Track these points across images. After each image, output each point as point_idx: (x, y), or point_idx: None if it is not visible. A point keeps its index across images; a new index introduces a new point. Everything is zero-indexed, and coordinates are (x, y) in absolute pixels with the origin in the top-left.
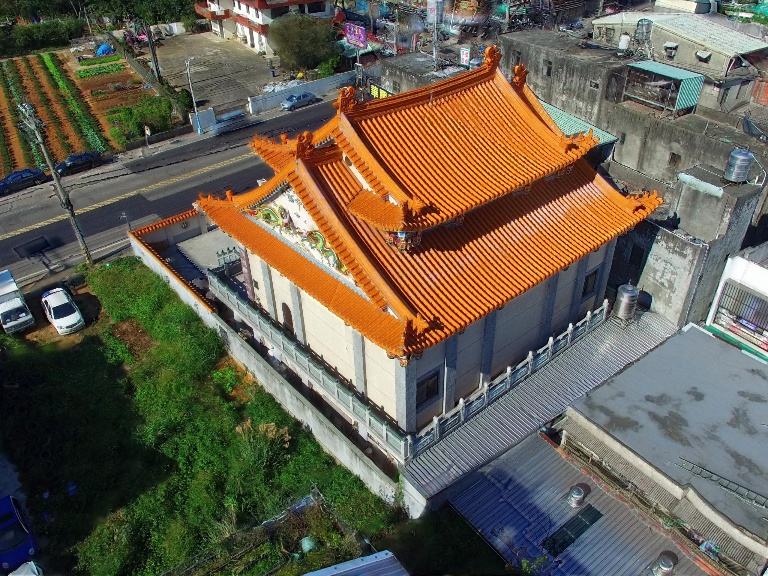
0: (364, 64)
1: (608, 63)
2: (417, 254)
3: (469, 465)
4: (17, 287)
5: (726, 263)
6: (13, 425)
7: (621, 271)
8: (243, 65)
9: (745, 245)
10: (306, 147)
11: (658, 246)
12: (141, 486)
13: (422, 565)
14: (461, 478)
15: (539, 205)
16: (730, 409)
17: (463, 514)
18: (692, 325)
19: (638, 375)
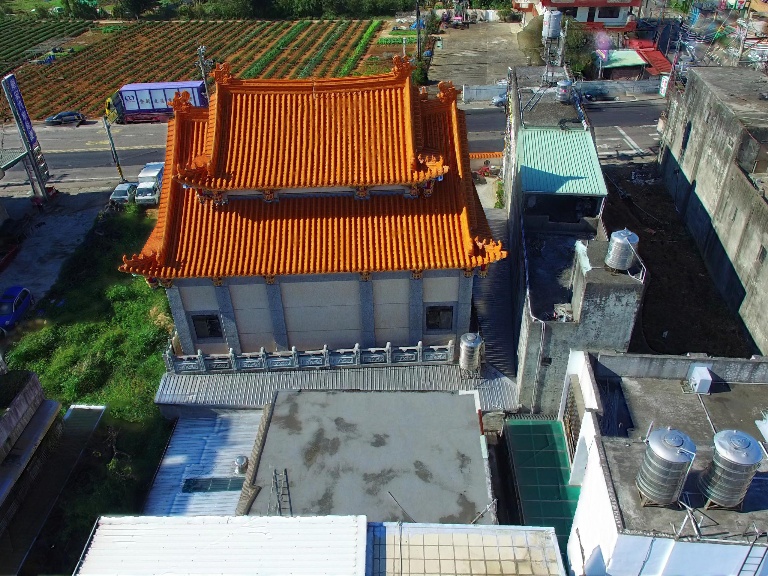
0: (616, 78)
1: (759, 121)
2: (219, 211)
3: (205, 400)
4: (157, 175)
5: (569, 354)
6: (76, 254)
7: (517, 328)
8: (509, 57)
9: (630, 351)
10: (183, 103)
11: (524, 309)
12: (83, 318)
13: (118, 443)
14: (191, 405)
15: (374, 214)
16: (386, 466)
17: (175, 431)
18: (474, 393)
19: (361, 401)
